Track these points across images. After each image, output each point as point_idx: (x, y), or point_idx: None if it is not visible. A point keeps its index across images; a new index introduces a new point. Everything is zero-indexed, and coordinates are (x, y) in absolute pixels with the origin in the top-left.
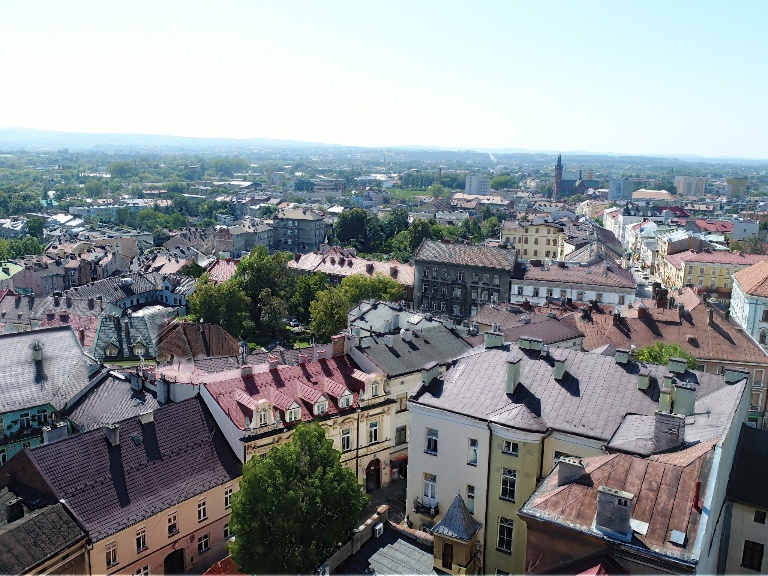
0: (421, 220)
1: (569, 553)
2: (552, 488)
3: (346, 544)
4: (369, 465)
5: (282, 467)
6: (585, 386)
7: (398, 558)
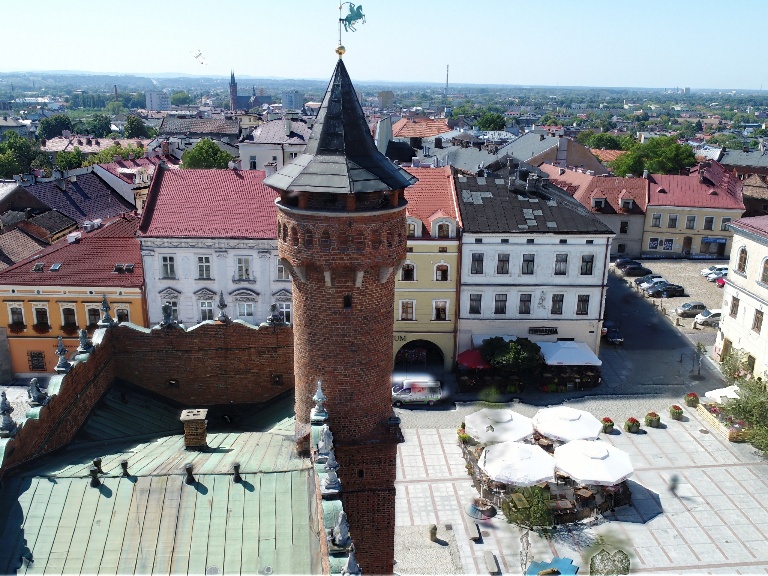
0: (135, 117)
1: None
2: None
3: None
4: None
5: None
6: None
7: None
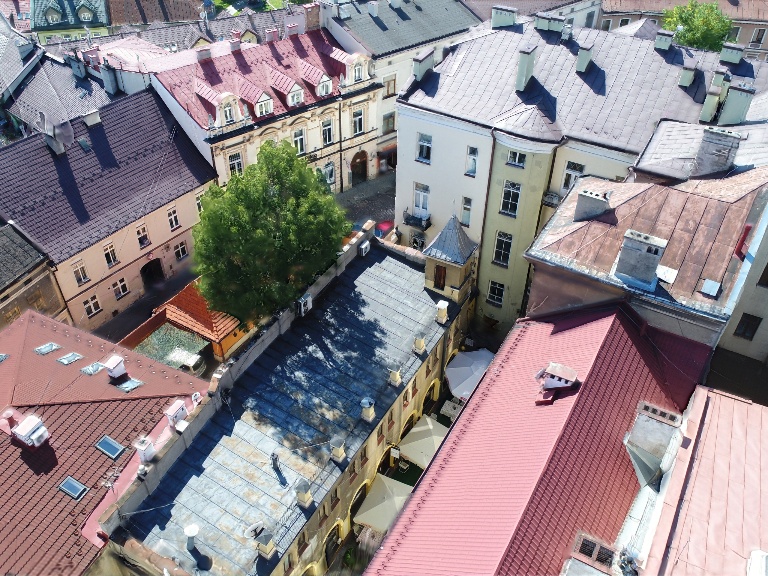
0: None
1: (579, 297)
2: (566, 222)
3: (329, 268)
4: (354, 158)
5: (246, 201)
6: (613, 81)
7: (386, 278)
